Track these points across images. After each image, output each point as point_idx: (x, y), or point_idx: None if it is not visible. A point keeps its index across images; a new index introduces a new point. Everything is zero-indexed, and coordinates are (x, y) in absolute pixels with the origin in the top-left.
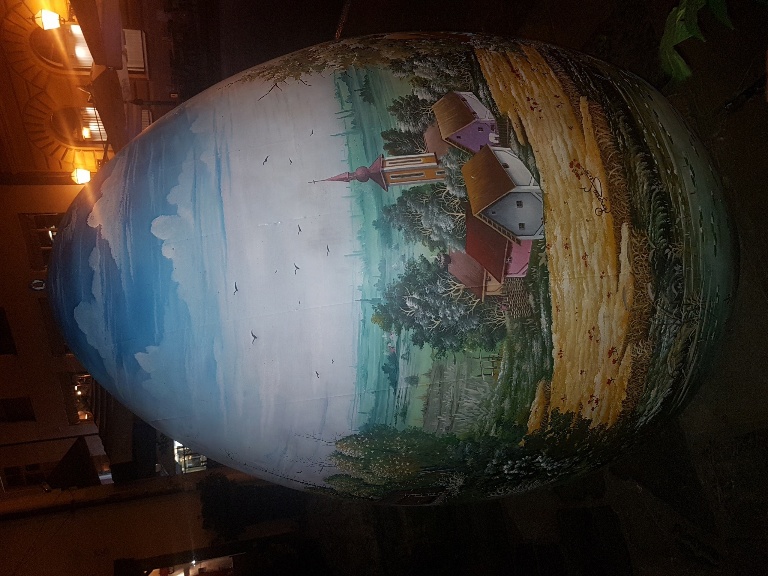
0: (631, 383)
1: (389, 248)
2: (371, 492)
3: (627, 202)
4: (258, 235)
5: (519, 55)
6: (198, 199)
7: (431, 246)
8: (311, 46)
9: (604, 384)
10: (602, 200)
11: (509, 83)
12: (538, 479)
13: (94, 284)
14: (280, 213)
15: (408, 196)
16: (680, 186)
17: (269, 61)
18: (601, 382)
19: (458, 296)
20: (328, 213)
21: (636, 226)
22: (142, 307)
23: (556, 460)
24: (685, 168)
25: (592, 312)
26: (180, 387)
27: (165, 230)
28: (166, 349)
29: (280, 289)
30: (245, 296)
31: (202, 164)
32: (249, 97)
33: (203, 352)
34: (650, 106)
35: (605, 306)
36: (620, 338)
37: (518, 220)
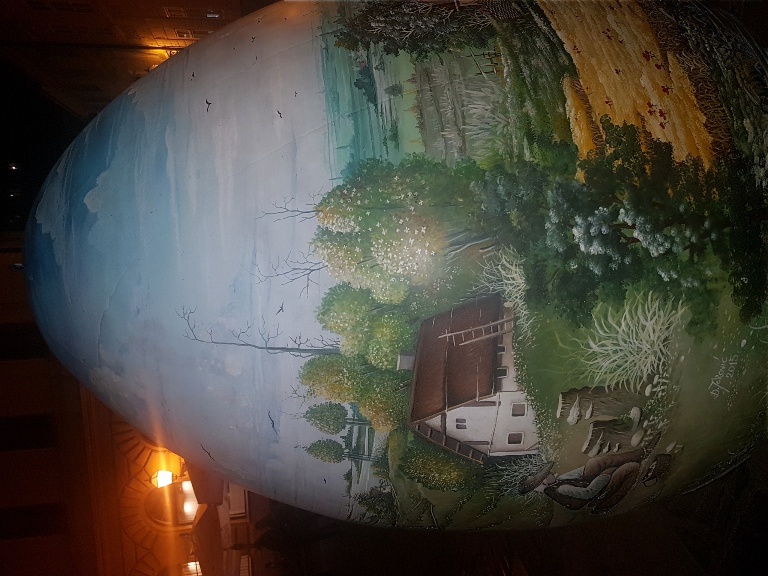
0: (701, 100)
1: (347, 0)
2: (393, 338)
3: None
4: (219, 40)
5: None
6: None
7: None
8: None
9: (659, 92)
10: None
11: None
12: (650, 290)
13: None
14: (242, 24)
15: None
16: None
17: None
18: (653, 88)
19: (428, 11)
20: (286, 6)
21: None
22: (99, 141)
23: (654, 228)
24: None
25: (598, 18)
26: (127, 208)
27: (135, 83)
28: (117, 167)
29: (237, 58)
30: (202, 77)
31: None
32: None
33: (154, 146)
34: None
35: (612, 15)
36: (651, 44)
37: None
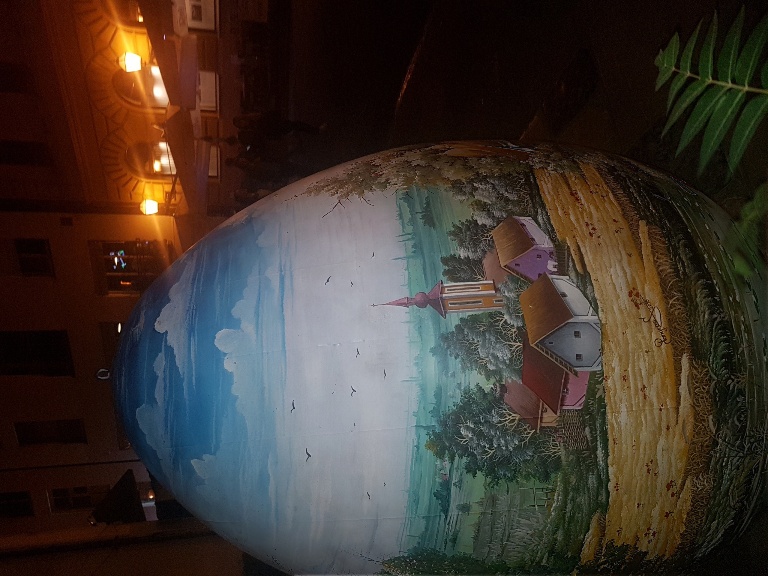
0: (690, 516)
1: (445, 376)
2: None
3: (688, 332)
4: (317, 355)
5: (578, 176)
6: (261, 315)
7: (487, 375)
8: (373, 158)
9: (662, 517)
10: (662, 330)
11: (568, 207)
12: None
13: (157, 389)
14: (339, 335)
15: (466, 324)
16: (743, 313)
17: (333, 172)
18: (659, 515)
19: (513, 426)
20: (386, 338)
21: (697, 357)
22: (202, 416)
23: None
24: (748, 294)
25: (650, 445)
26: (233, 496)
27: (228, 344)
28: (222, 459)
29: (336, 410)
30: (302, 414)
31: (266, 280)
32: (313, 213)
33: (258, 465)
34: (711, 227)
35: (664, 439)
36: (679, 471)
37: (576, 351)
